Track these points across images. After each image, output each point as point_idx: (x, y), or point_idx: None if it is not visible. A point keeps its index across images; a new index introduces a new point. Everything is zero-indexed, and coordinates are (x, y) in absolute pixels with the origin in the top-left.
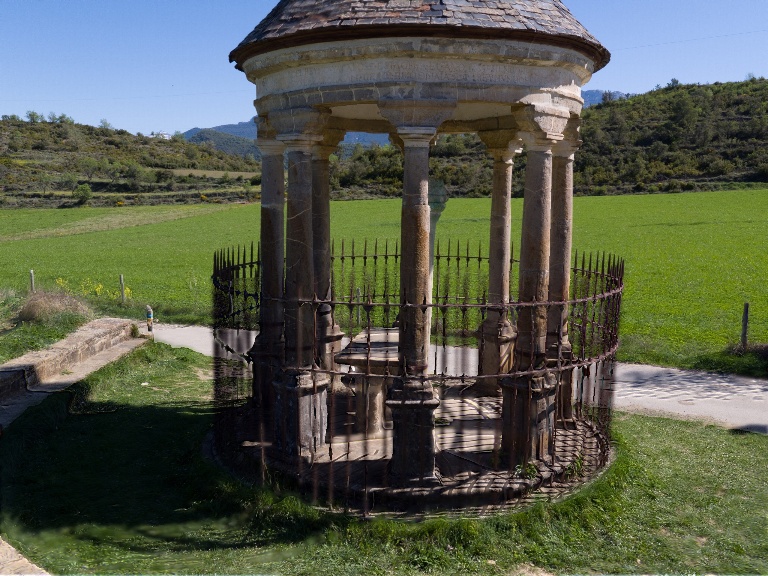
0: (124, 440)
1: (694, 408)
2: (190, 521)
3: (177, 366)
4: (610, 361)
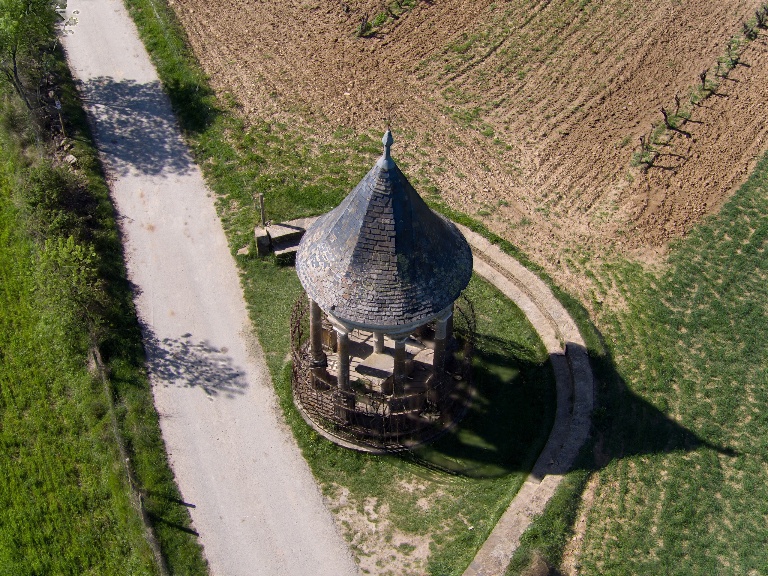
0: (500, 435)
1: (231, 344)
2: (491, 361)
3: (439, 567)
4: (161, 426)
